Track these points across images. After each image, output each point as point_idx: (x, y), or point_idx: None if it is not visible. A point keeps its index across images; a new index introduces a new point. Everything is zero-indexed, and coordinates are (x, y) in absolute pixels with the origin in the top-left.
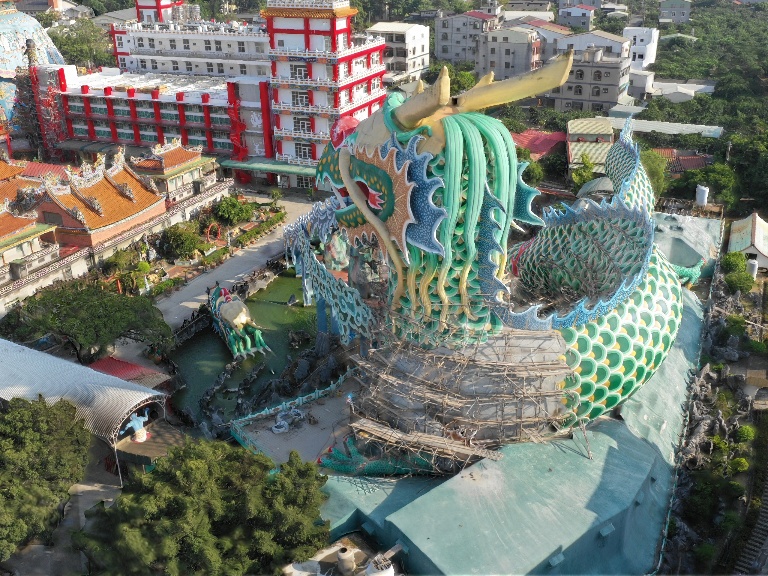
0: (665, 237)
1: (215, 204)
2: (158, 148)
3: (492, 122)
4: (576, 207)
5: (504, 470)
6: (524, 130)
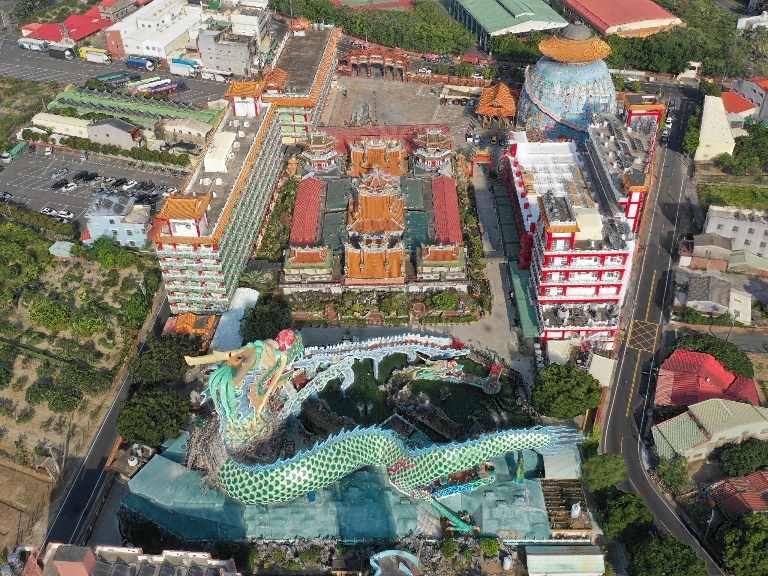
0: (480, 499)
1: (445, 291)
2: (433, 246)
3: (229, 379)
4: None
5: (183, 474)
6: (744, 376)
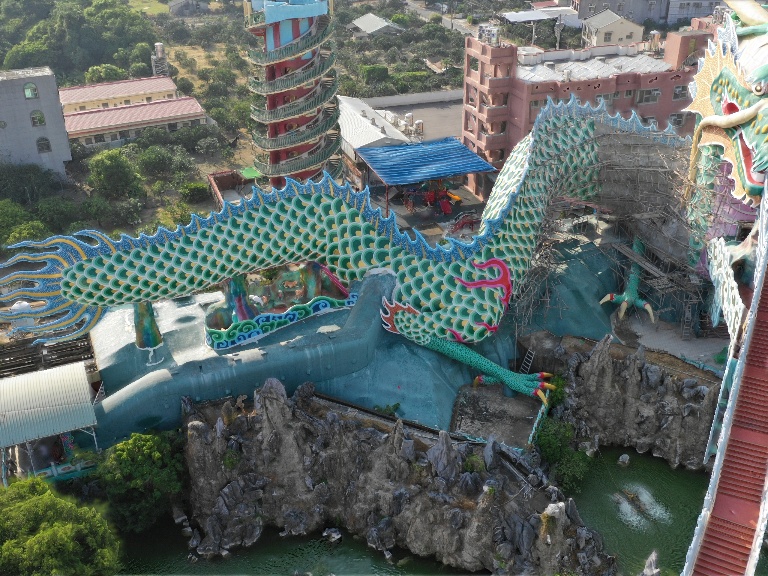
0: None
1: None
2: None
3: None
4: (225, 358)
5: None
6: None
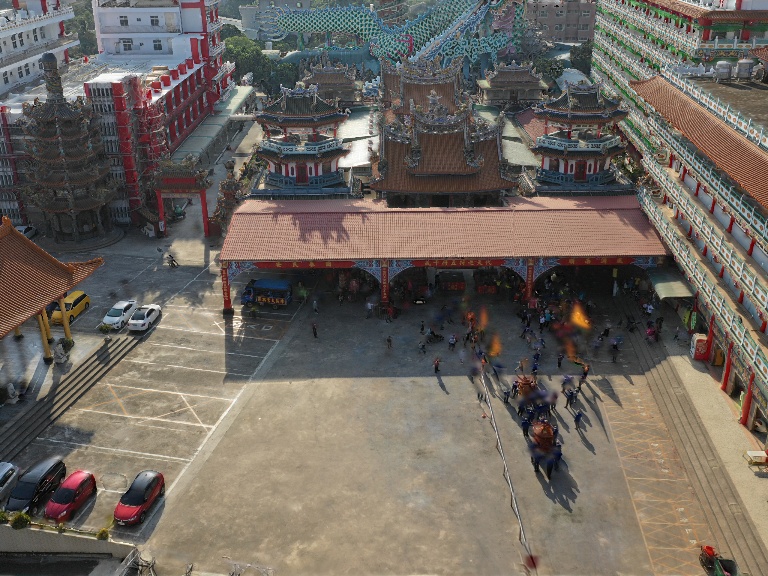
0: None
1: None
2: (341, 67)
3: None
4: (317, 50)
5: None
6: None
